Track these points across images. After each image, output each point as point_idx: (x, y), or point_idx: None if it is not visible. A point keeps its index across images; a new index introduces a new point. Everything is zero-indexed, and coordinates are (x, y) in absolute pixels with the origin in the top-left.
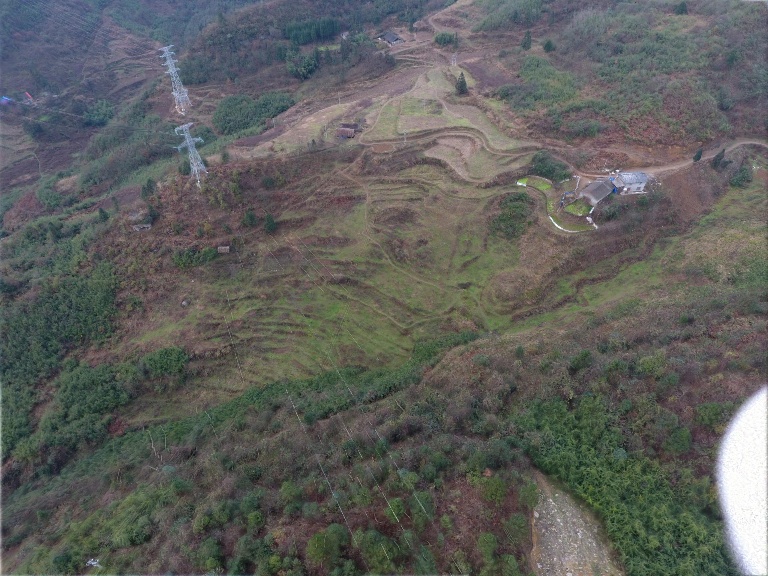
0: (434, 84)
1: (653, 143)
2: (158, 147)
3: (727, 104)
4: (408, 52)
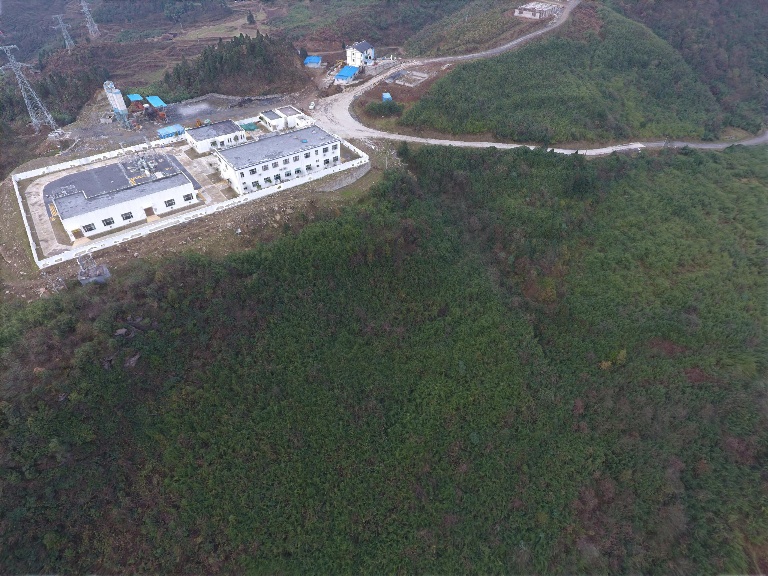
0: (244, 21)
1: (322, 39)
2: (47, 29)
3: (382, 25)
4: (242, 6)
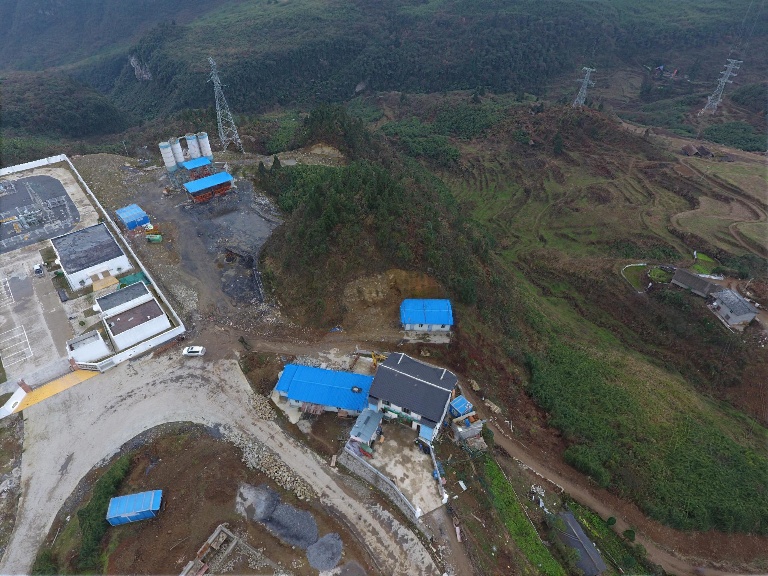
0: None
1: None
2: None
3: None
4: None
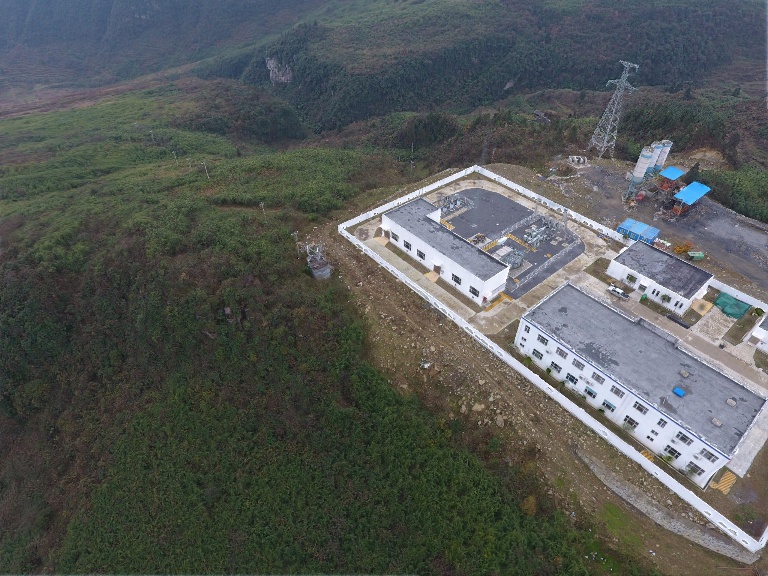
0: None
1: None
2: None
3: None
4: None
